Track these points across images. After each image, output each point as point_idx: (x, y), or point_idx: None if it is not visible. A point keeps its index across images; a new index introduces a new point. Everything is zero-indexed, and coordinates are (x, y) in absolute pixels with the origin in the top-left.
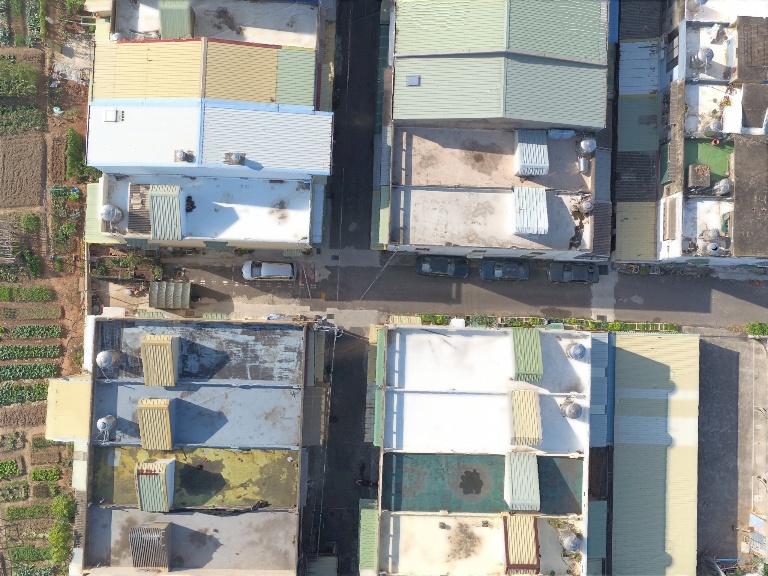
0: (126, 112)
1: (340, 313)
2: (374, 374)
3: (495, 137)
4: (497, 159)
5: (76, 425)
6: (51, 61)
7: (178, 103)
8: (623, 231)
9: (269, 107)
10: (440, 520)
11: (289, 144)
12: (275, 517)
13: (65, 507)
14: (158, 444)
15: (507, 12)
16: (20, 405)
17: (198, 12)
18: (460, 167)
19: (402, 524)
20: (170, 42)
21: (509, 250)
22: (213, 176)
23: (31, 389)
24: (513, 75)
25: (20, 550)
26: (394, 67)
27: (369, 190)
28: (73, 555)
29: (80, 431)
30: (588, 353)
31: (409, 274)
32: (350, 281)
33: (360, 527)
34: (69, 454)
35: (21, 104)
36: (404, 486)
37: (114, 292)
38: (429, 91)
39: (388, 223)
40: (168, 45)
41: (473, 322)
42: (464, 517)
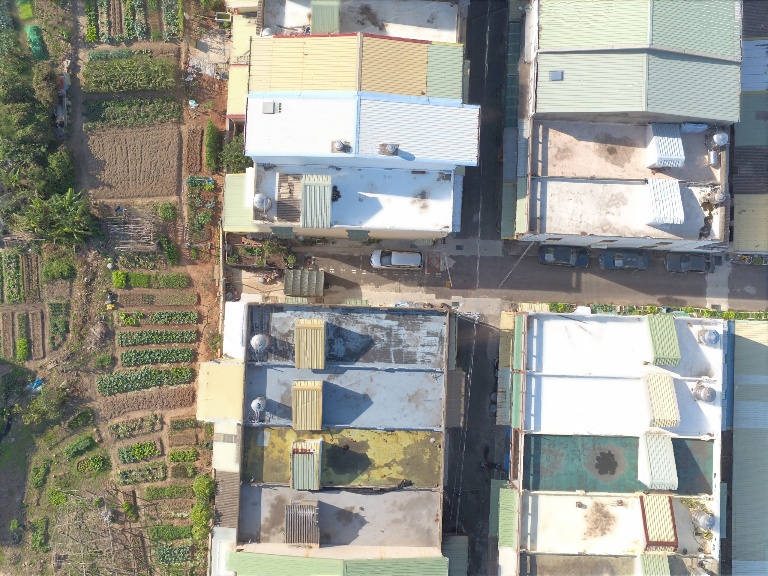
0: (283, 104)
1: (464, 301)
2: (505, 359)
3: (628, 131)
4: (629, 152)
5: (226, 406)
6: (186, 55)
7: (335, 96)
8: (741, 223)
9: (420, 100)
10: (577, 499)
11: (439, 136)
12: (418, 496)
13: (207, 487)
14: (309, 425)
15: (650, 10)
16: (158, 388)
17: (342, 8)
18: (594, 159)
19: (540, 503)
20: (326, 37)
21: (641, 240)
22: (359, 167)
23: (169, 373)
24: (655, 70)
25: (159, 529)
26: (537, 62)
27: (492, 182)
28: (214, 533)
29: (230, 412)
30: (720, 339)
31: (531, 264)
32: (474, 270)
33: (499, 506)
34: (206, 436)
35: (158, 97)
36: (542, 467)
37: (247, 280)
38: (572, 86)
39: (526, 213)
40: (324, 40)
41: (597, 310)
42: (600, 497)
